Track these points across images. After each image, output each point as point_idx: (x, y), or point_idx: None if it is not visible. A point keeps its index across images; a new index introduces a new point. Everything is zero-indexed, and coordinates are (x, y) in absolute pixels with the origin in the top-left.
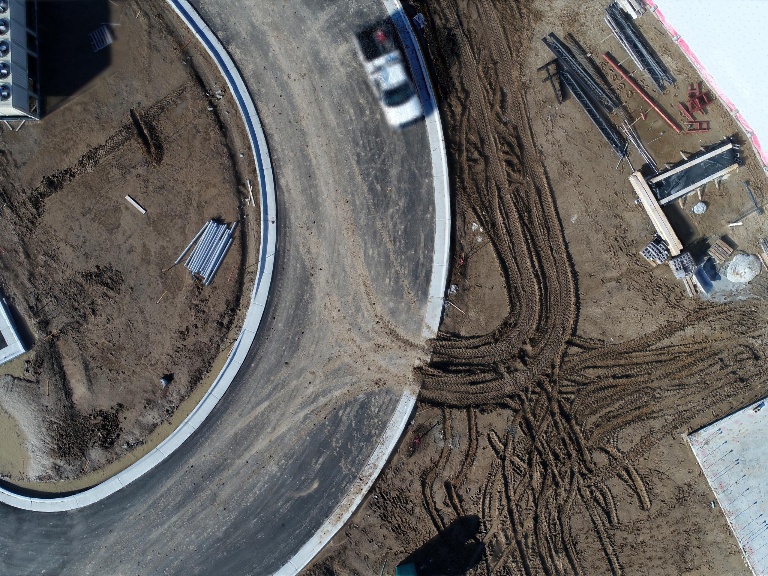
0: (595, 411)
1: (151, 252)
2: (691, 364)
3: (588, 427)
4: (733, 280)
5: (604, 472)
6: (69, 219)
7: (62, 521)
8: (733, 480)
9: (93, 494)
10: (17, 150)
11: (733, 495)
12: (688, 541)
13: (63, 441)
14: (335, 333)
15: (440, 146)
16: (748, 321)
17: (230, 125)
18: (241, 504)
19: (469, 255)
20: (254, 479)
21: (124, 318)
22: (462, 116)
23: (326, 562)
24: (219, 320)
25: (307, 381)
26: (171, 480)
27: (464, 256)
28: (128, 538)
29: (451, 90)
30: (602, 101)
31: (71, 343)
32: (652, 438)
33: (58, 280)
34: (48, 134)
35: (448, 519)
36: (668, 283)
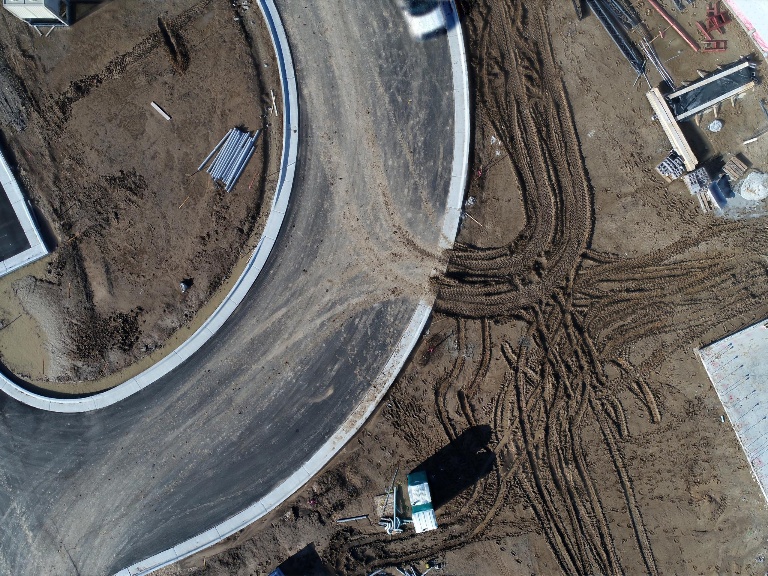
0: (608, 324)
1: (174, 158)
2: (704, 280)
3: (601, 340)
4: (747, 197)
5: (615, 385)
6: (95, 124)
7: (79, 422)
8: (743, 395)
9: (111, 396)
10: (46, 55)
11: (743, 410)
12: (697, 455)
13: (83, 343)
14: (353, 242)
15: (461, 59)
16: (761, 238)
17: (255, 35)
18: (256, 409)
19: (487, 168)
20: (270, 385)
21: (146, 222)
22: (483, 31)
23: (339, 469)
24: (239, 227)
25: (324, 289)
26: (188, 384)
27: (482, 169)
28: (144, 440)
29: (473, 5)
30: (621, 18)
31: (93, 246)
32: (664, 352)
33: (82, 184)
34: (77, 40)
35: (460, 429)
36: (683, 199)
